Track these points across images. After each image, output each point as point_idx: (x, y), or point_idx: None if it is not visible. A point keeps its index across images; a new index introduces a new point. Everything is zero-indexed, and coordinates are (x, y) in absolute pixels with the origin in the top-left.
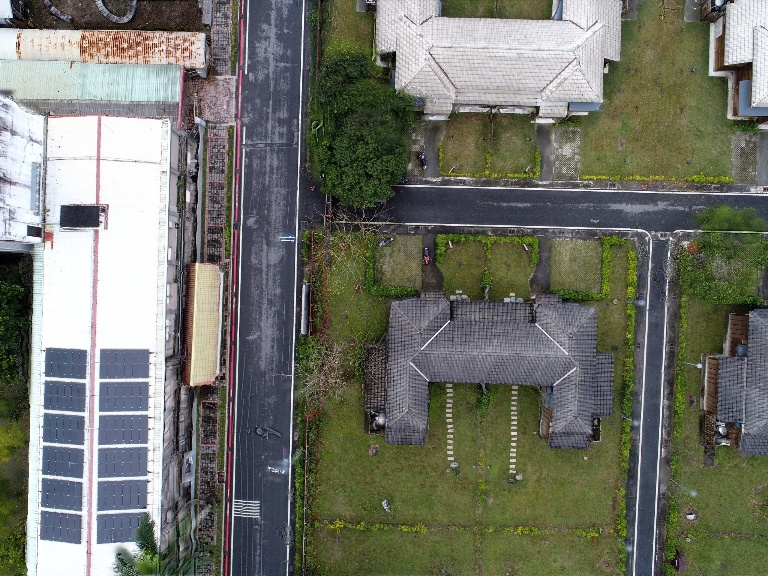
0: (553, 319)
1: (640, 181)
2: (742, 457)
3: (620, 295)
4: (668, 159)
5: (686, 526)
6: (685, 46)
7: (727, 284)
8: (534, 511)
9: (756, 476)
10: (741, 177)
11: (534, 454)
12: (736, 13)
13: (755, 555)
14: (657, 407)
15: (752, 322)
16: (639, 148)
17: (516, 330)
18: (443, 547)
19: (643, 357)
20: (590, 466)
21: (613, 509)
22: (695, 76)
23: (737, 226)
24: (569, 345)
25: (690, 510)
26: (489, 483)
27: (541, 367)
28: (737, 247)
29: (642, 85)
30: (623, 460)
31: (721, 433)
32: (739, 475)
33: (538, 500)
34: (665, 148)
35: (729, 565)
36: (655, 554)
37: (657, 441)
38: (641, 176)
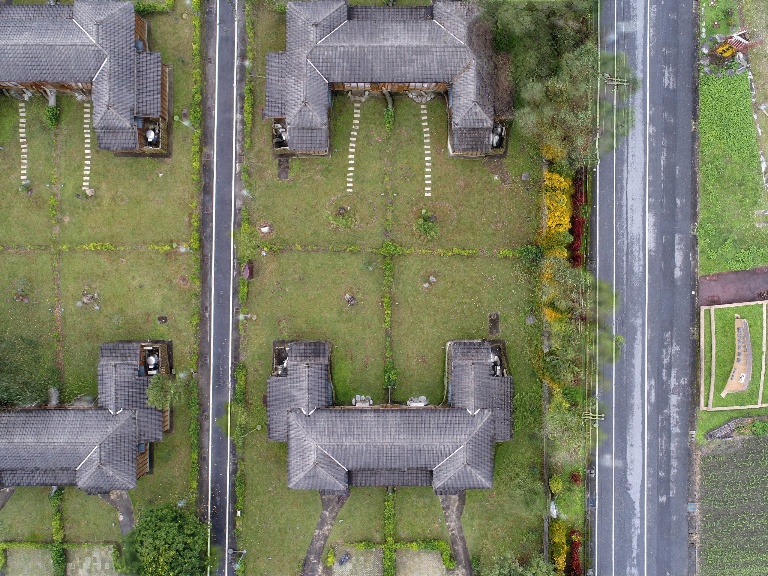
0: (83, 10)
1: None
2: (316, 169)
3: (189, 9)
4: None
5: (262, 240)
6: None
7: None
8: (111, 229)
9: (330, 188)
10: None
11: (108, 172)
12: None
13: (332, 267)
14: (230, 121)
15: (288, 11)
16: None
17: (51, 24)
18: (21, 268)
19: (215, 72)
20: (165, 182)
21: (190, 225)
22: None
23: None
24: (95, 32)
25: (265, 223)
26: (64, 202)
27: (72, 58)
28: None
29: None
30: (193, 173)
31: (284, 139)
32: (314, 187)
33: (114, 218)
34: None
35: (306, 278)
36: (233, 269)
37: (231, 156)
38: None
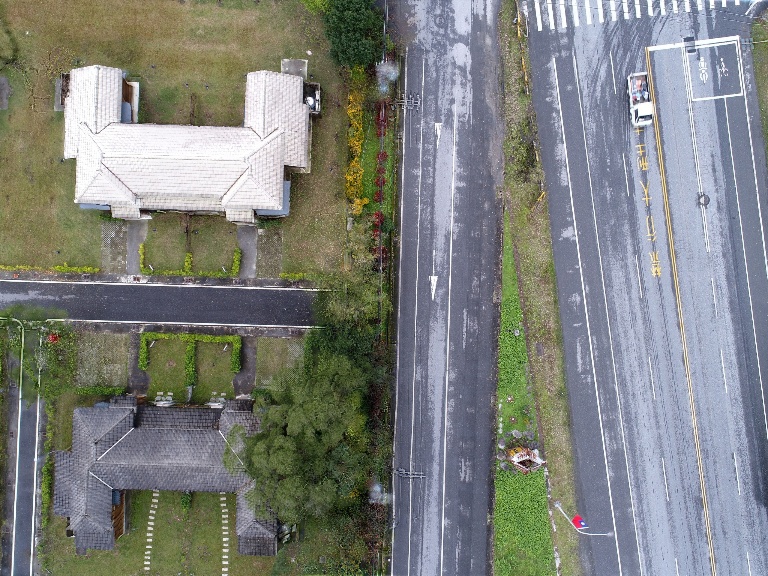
0: None
1: (8, 270)
2: (113, 546)
3: None
4: (39, 248)
5: None
6: (55, 135)
7: (97, 373)
8: None
9: (128, 565)
10: (111, 266)
11: None
12: (70, 108)
13: None
14: (30, 496)
15: (74, 418)
16: (10, 237)
17: None
18: None
19: (16, 446)
20: None
21: None
22: (65, 165)
23: (107, 315)
24: None
25: None
26: None
27: None
28: (108, 336)
29: (13, 174)
30: None
31: None
32: (111, 564)
33: None
34: (36, 237)
35: None
36: None
37: (30, 530)
38: (7, 266)
